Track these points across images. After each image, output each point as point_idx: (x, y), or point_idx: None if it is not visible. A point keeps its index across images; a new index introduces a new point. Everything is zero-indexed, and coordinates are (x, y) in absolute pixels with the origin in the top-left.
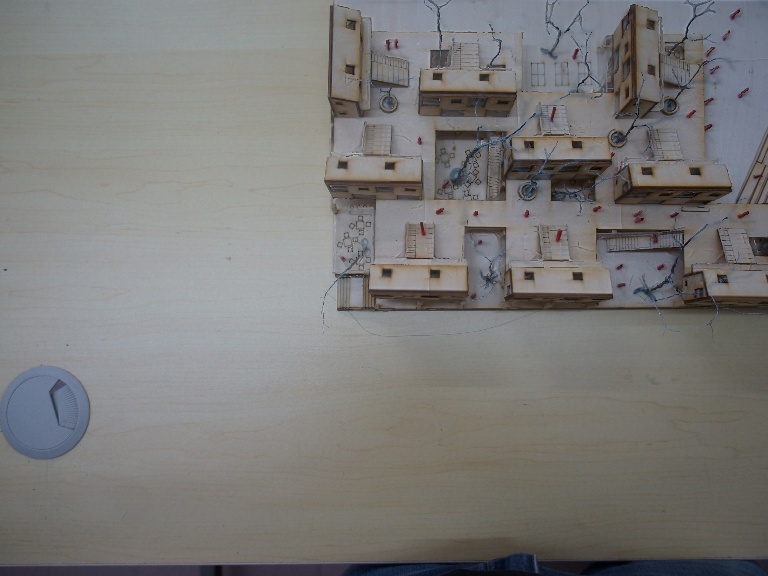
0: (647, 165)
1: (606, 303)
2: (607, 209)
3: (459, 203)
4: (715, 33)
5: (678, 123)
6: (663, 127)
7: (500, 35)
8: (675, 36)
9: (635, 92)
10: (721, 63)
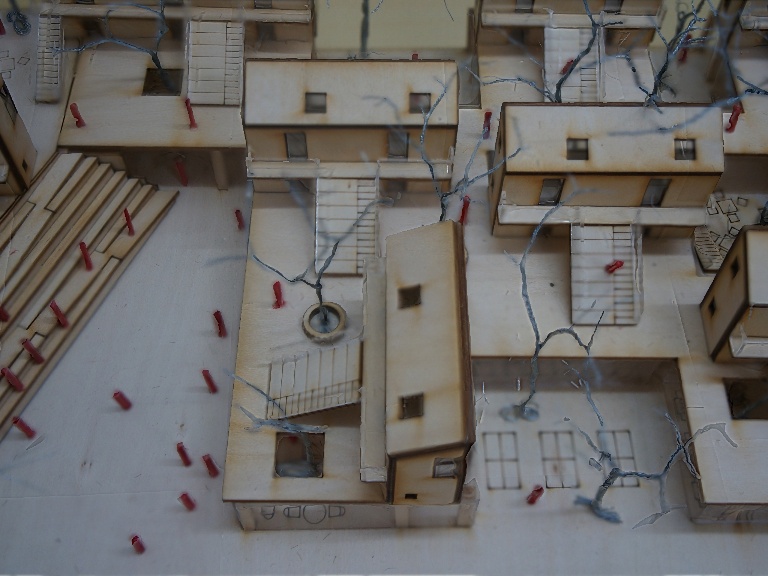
0: (417, 119)
1: (439, 54)
2: (462, 138)
3: (767, 149)
4: (161, 567)
5: (305, 291)
6: (340, 283)
7: (764, 495)
8: (296, 493)
9: (457, 233)
10: (158, 486)
